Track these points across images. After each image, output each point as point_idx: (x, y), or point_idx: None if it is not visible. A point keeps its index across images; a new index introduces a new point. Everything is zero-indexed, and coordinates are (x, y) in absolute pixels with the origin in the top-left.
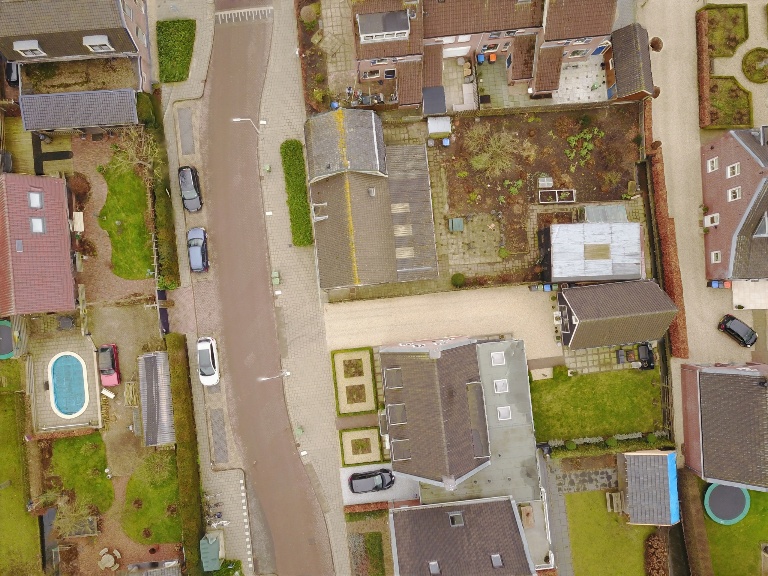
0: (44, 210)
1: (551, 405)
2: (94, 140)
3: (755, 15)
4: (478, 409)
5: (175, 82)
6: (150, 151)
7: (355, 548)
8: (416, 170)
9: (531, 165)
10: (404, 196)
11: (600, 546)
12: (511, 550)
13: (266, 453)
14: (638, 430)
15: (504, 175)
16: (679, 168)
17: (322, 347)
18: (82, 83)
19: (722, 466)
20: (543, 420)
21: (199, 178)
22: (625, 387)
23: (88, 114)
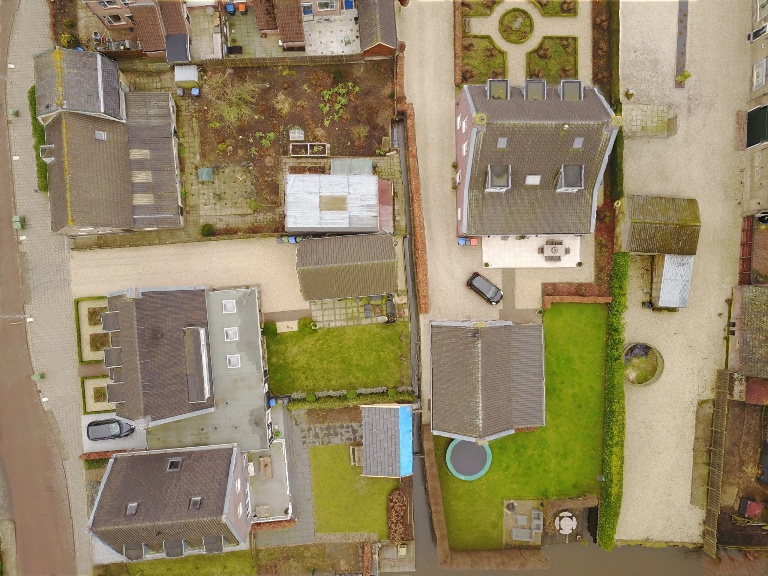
0: None
1: (297, 358)
2: None
3: None
4: (195, 354)
5: None
6: None
7: (93, 496)
8: (158, 117)
9: (284, 118)
10: (144, 143)
11: (342, 499)
12: (212, 493)
13: (6, 399)
14: (384, 385)
15: (257, 127)
16: (434, 125)
17: (67, 294)
18: None
19: (445, 418)
20: (288, 372)
21: None
22: (372, 342)
23: None
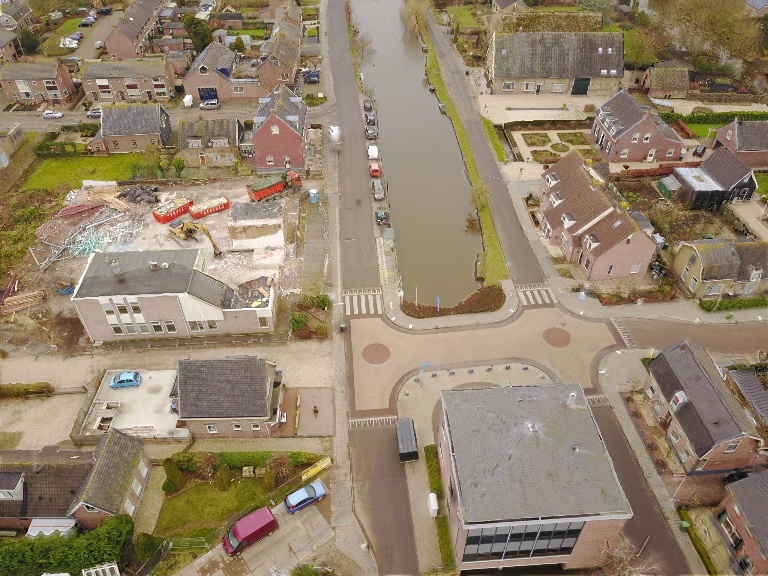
0: None
1: None
2: None
3: None
4: None
5: None
6: (766, 370)
7: None
8: None
9: None
10: None
11: None
12: None
13: None
14: None
15: None
16: None
17: None
18: None
19: None
20: None
21: None
22: None
23: (766, 402)
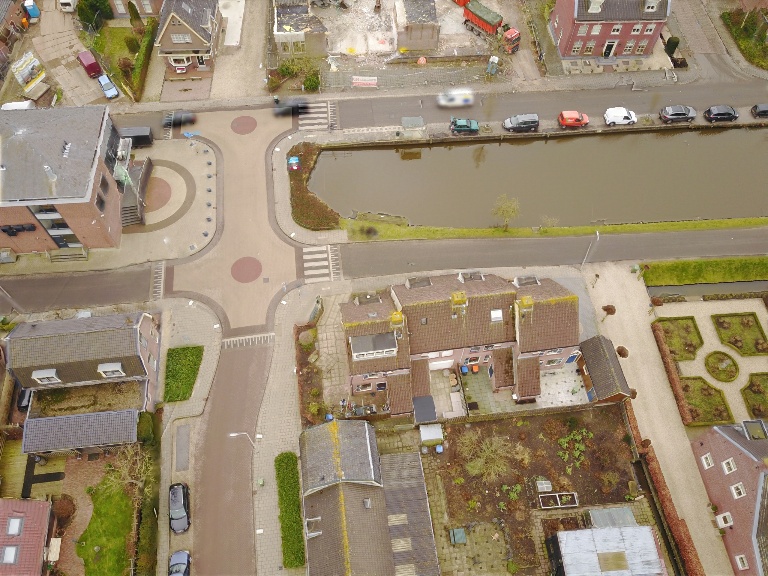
0: (21, 537)
1: None
2: (89, 460)
3: (703, 325)
4: None
5: (178, 401)
6: (144, 469)
7: None
8: (411, 478)
9: (527, 468)
10: (401, 506)
11: None
12: None
13: None
14: None
15: (501, 480)
16: (675, 466)
17: None
18: (89, 405)
19: None
20: None
21: (190, 495)
22: None
23: (89, 434)
